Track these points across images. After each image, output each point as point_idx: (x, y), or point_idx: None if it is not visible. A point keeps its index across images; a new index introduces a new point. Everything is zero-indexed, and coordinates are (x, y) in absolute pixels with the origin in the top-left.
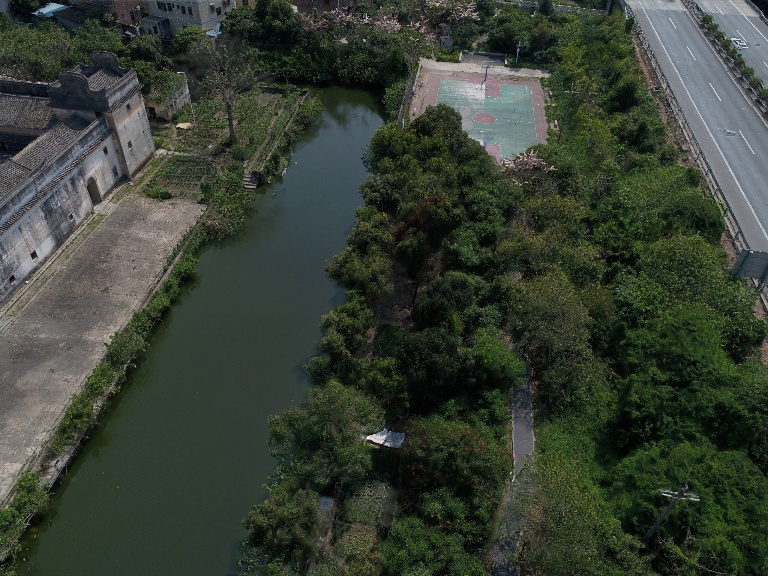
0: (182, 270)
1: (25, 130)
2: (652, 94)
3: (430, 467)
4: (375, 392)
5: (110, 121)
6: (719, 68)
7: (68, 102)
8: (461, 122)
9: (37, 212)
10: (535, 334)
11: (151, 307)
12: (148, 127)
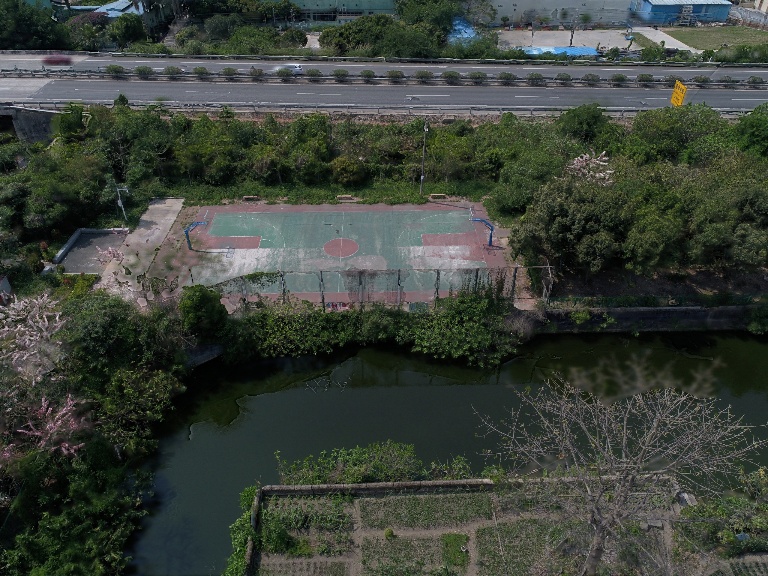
0: None
1: None
2: None
3: None
4: None
5: None
6: (255, 86)
7: None
8: None
9: None
10: None
11: None
12: None
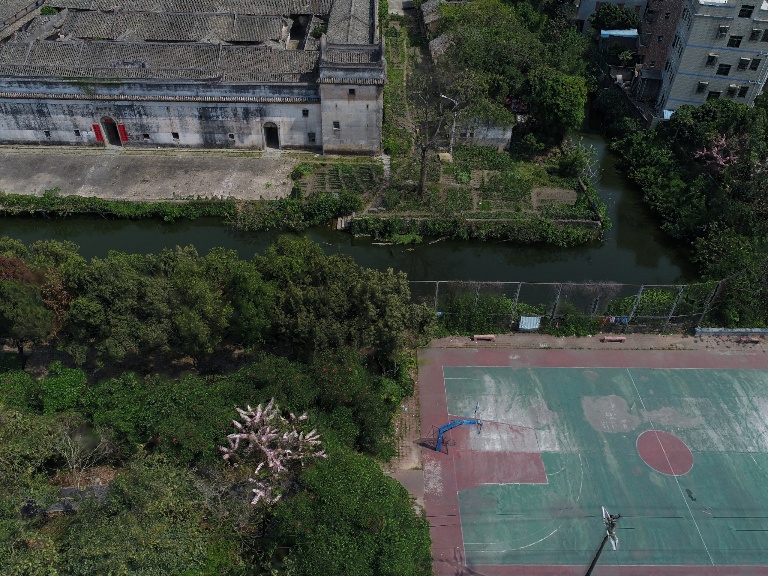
0: (157, 206)
1: None
2: None
3: None
4: None
5: None
6: None
7: None
8: (384, 328)
9: (192, 109)
10: None
11: (101, 201)
12: (379, 126)
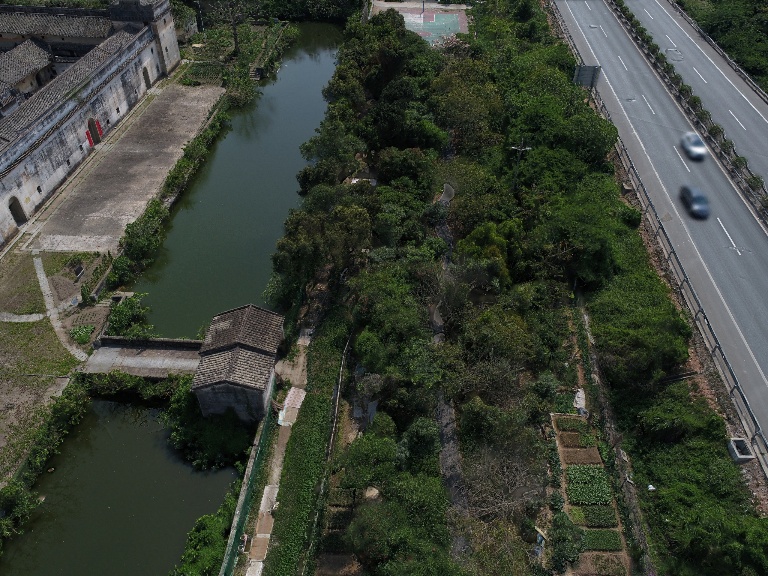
0: (220, 117)
1: (89, 41)
2: (543, 10)
3: (393, 167)
4: (359, 134)
5: (154, 29)
6: None
7: (124, 16)
8: None
9: (118, 80)
10: (454, 120)
11: (205, 133)
12: (176, 40)
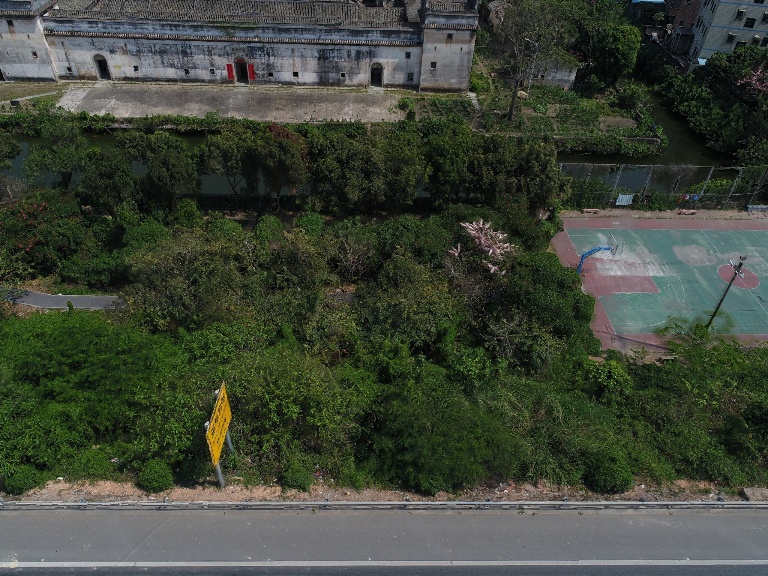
0: (301, 126)
1: None
2: None
3: None
4: None
5: None
6: None
7: None
8: (546, 180)
9: (313, 51)
10: None
11: (254, 121)
12: (469, 66)
